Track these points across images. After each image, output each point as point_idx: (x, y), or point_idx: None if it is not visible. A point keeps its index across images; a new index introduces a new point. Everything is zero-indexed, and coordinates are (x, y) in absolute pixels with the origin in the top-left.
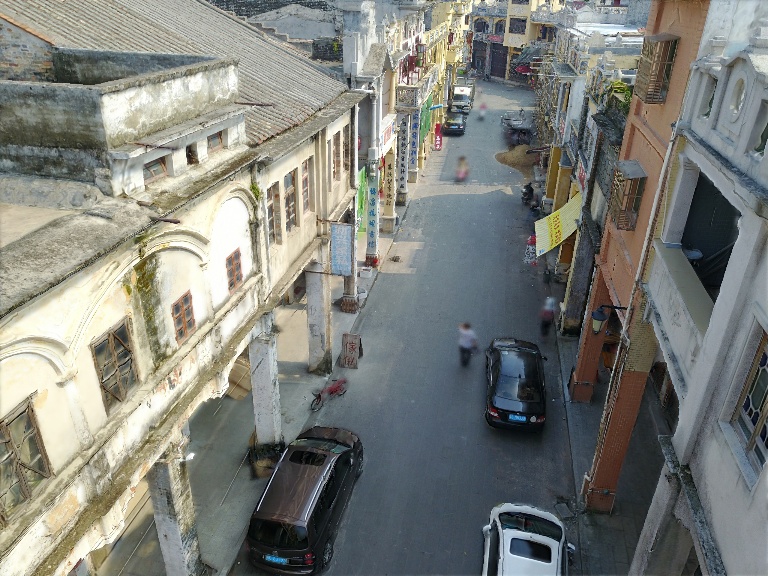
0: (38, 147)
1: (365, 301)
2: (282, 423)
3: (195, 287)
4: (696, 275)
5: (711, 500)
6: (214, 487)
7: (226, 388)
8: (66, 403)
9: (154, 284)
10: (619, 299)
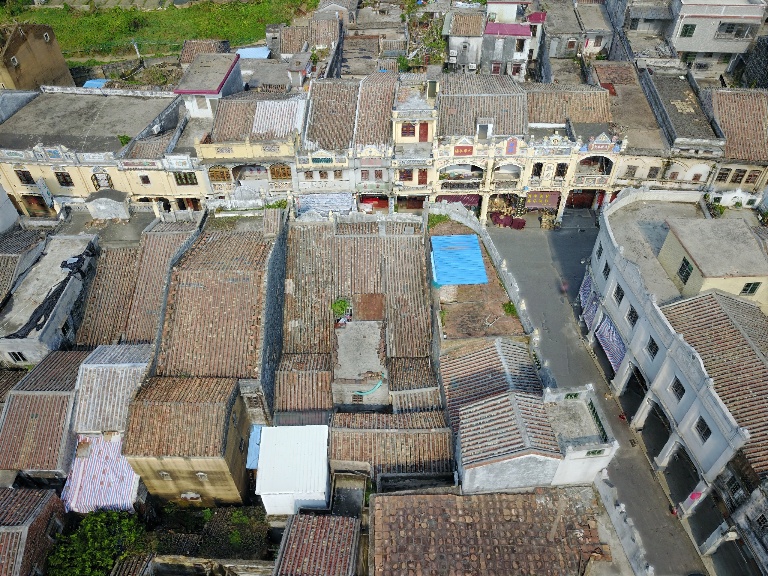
0: (670, 138)
1: None
2: None
3: (681, 173)
4: None
5: None
6: None
7: None
8: (642, 171)
9: (670, 166)
10: None
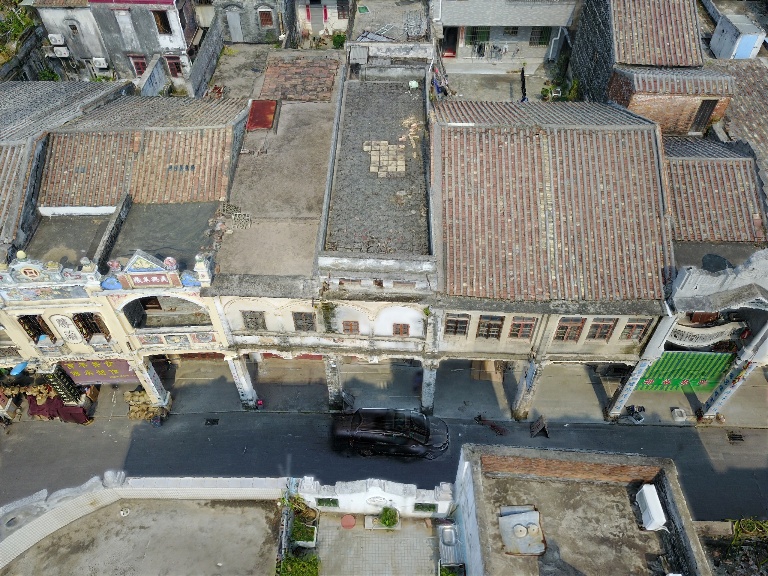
0: None
1: (633, 425)
2: (458, 406)
3: (363, 322)
4: None
5: None
6: (400, 389)
7: (374, 362)
8: (276, 319)
9: (333, 311)
10: None
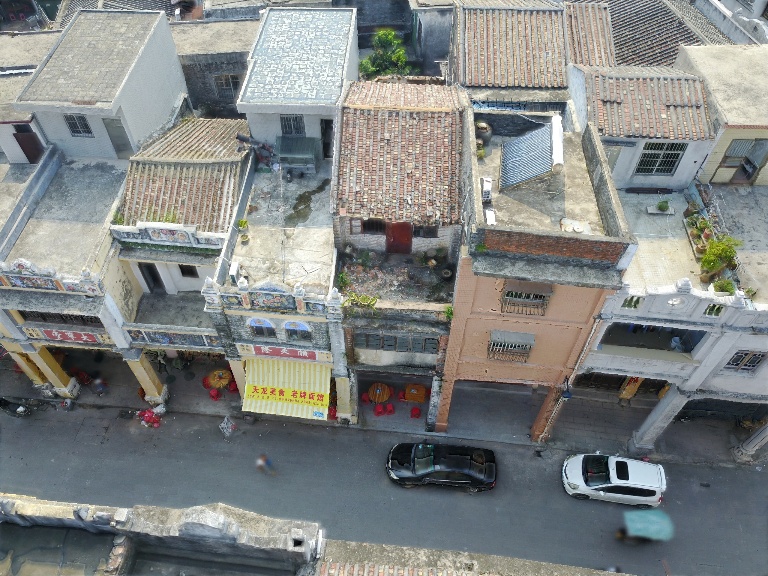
0: None
1: None
2: None
3: None
4: (634, 348)
5: (722, 387)
6: None
7: None
8: None
9: None
10: (518, 379)
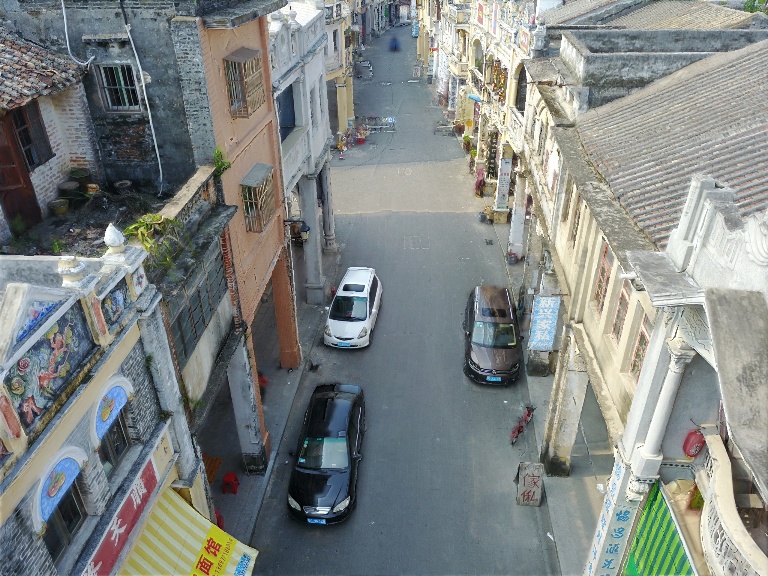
0: None
1: None
2: None
3: None
4: None
5: None
6: None
7: None
8: None
9: None
10: None
